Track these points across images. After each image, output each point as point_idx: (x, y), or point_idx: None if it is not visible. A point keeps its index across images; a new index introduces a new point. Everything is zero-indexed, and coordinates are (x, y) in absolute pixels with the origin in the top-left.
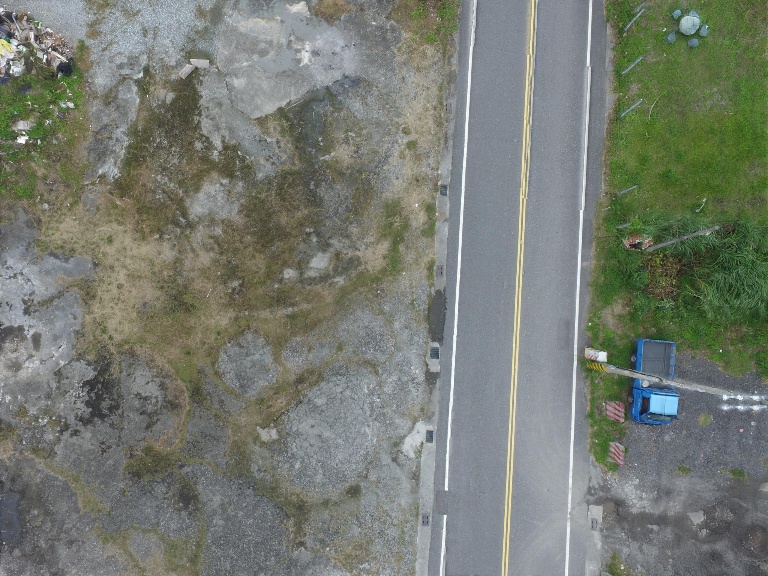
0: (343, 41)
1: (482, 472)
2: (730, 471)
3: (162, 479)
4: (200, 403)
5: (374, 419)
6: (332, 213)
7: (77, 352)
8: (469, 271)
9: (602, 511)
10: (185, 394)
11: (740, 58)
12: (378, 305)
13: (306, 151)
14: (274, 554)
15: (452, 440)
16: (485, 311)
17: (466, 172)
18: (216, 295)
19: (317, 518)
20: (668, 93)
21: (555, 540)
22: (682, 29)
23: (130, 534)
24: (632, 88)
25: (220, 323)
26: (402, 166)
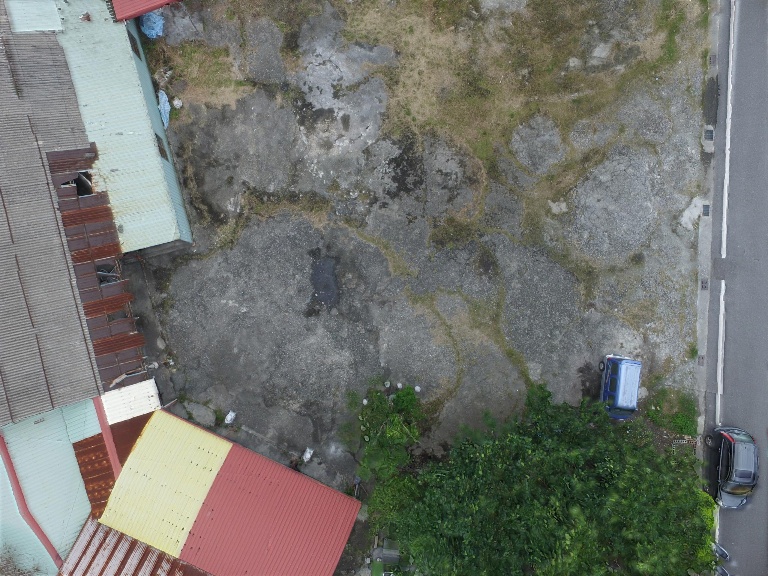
0: None
1: (756, 241)
2: None
3: (463, 247)
4: (496, 179)
5: (655, 194)
6: (613, 7)
7: (383, 132)
8: (740, 60)
9: None
10: (482, 171)
11: None
12: (657, 91)
13: None
14: (568, 314)
15: (728, 212)
16: (756, 96)
17: None
18: (508, 81)
19: (605, 283)
20: None
21: None
22: None
23: (437, 295)
24: None
25: (513, 106)
26: None
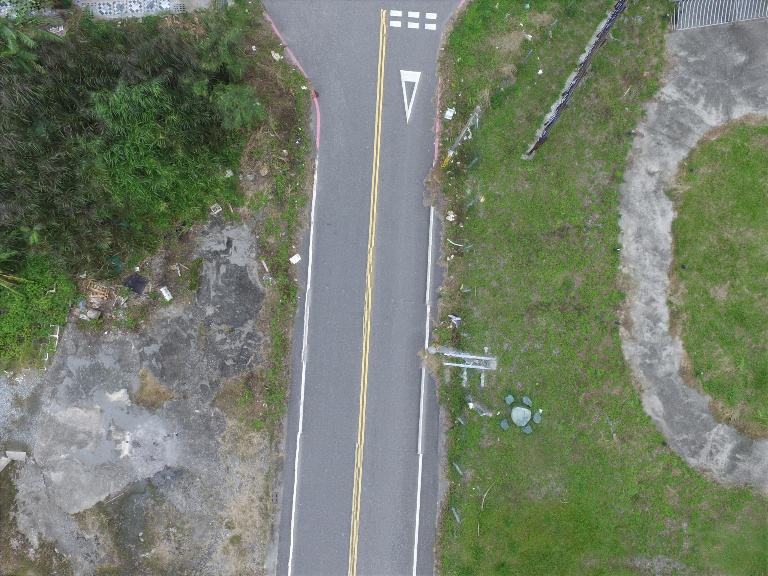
0: (165, 430)
1: None
2: None
3: None
4: None
5: None
6: None
7: None
8: None
9: None
10: None
11: (575, 443)
12: None
13: (126, 547)
14: None
15: None
16: None
17: (291, 569)
18: None
19: None
20: (501, 481)
21: None
22: (513, 420)
23: None
24: (465, 475)
25: None
26: (226, 562)
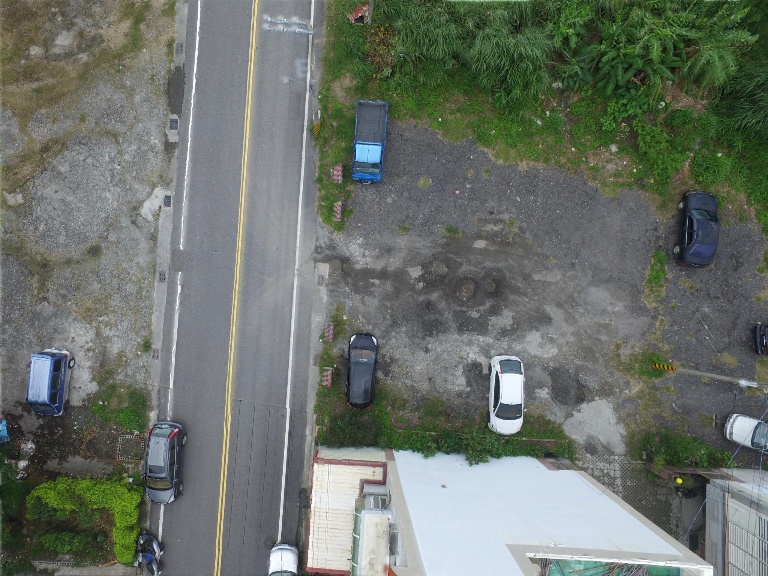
0: None
1: (215, 232)
2: (446, 229)
3: None
4: None
5: (115, 185)
6: None
7: None
8: (206, 48)
9: (328, 268)
10: None
11: None
12: (120, 79)
13: None
14: (18, 308)
15: (187, 203)
16: (220, 84)
17: None
18: None
19: (60, 275)
20: None
21: (283, 294)
22: None
23: None
24: None
25: None
26: None
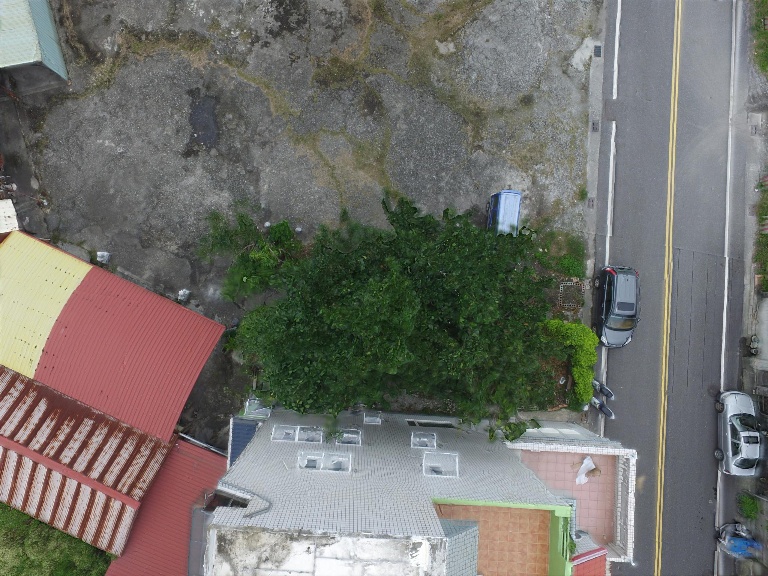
0: None
1: (648, 81)
2: None
3: (348, 87)
4: (382, 18)
5: (545, 34)
6: None
7: None
8: None
9: (761, 119)
10: (367, 10)
11: None
12: None
13: None
14: (454, 155)
15: (620, 52)
16: None
17: None
18: None
19: (493, 124)
20: None
21: (717, 144)
22: None
23: (319, 136)
24: None
25: None
26: None
